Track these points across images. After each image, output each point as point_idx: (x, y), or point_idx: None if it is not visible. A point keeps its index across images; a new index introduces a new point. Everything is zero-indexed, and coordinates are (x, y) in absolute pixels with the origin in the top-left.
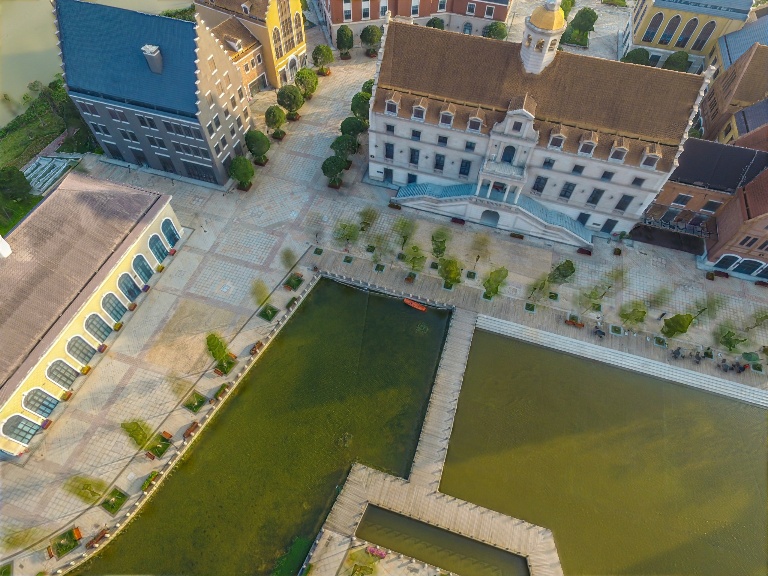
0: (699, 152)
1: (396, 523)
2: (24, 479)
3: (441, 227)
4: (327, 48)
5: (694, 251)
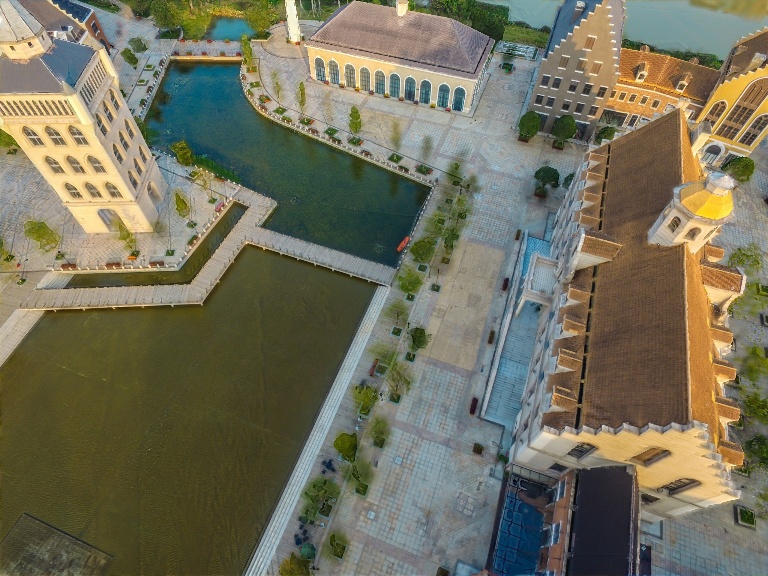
0: (615, 518)
1: (235, 222)
2: (299, 82)
3: (497, 270)
4: (748, 165)
5: (489, 569)
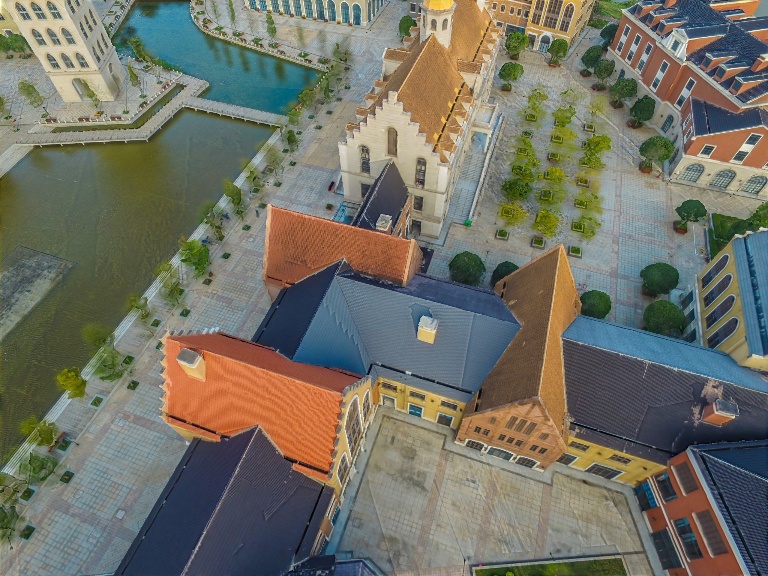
0: None
1: None
2: None
3: None
4: (562, 43)
5: None
